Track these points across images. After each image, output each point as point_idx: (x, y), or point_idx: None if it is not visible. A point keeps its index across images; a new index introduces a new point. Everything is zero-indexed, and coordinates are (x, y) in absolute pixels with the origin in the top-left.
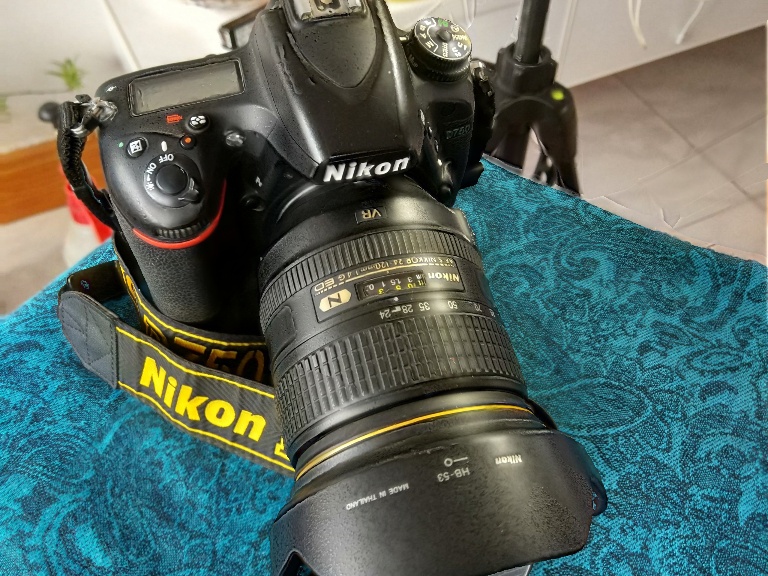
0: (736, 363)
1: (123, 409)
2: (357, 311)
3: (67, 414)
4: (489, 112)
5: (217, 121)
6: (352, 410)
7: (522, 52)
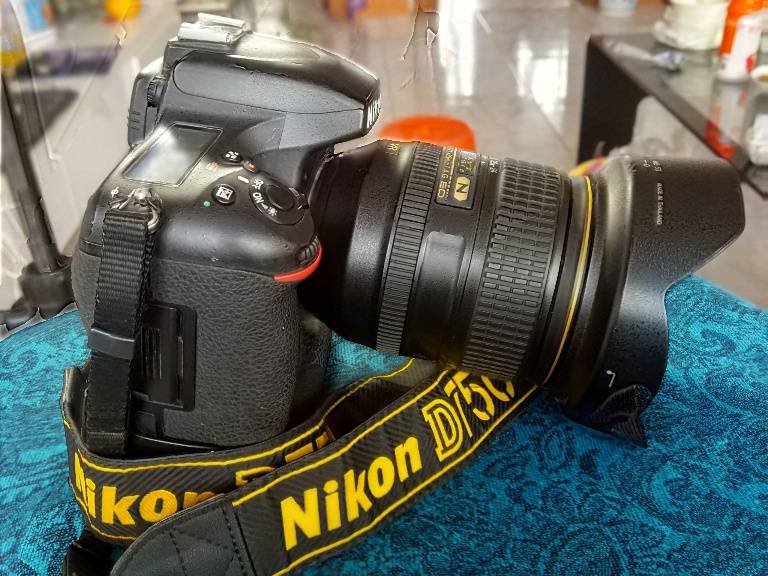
0: None
1: None
2: (481, 181)
3: None
4: None
5: None
6: (562, 218)
7: (47, 262)
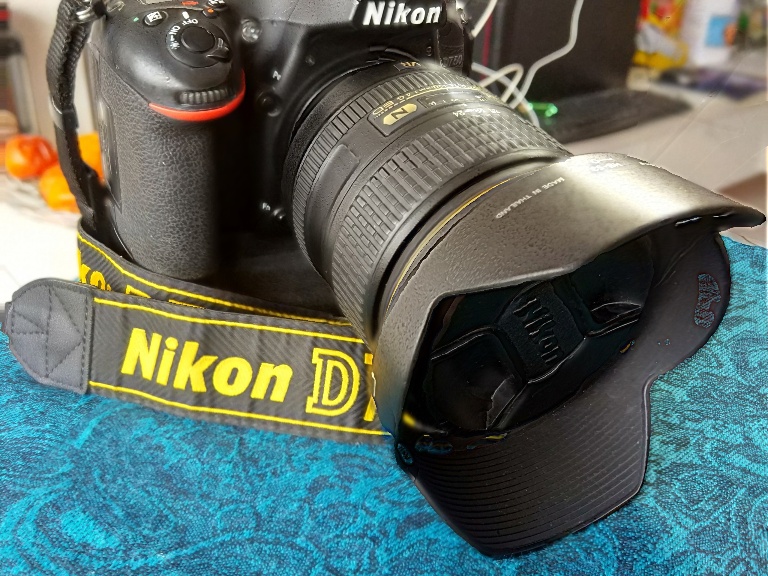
0: (742, 303)
1: (99, 409)
2: (428, 116)
3: (25, 421)
4: (468, 68)
5: (234, 9)
6: (454, 182)
7: None
